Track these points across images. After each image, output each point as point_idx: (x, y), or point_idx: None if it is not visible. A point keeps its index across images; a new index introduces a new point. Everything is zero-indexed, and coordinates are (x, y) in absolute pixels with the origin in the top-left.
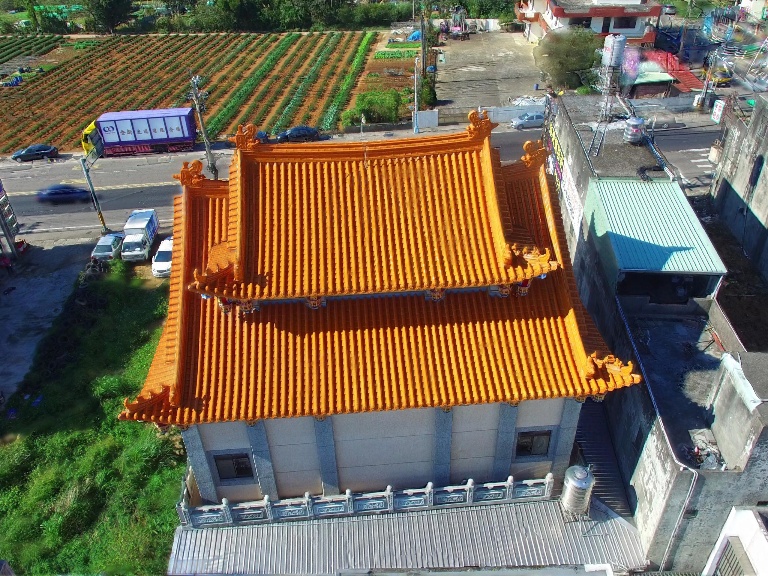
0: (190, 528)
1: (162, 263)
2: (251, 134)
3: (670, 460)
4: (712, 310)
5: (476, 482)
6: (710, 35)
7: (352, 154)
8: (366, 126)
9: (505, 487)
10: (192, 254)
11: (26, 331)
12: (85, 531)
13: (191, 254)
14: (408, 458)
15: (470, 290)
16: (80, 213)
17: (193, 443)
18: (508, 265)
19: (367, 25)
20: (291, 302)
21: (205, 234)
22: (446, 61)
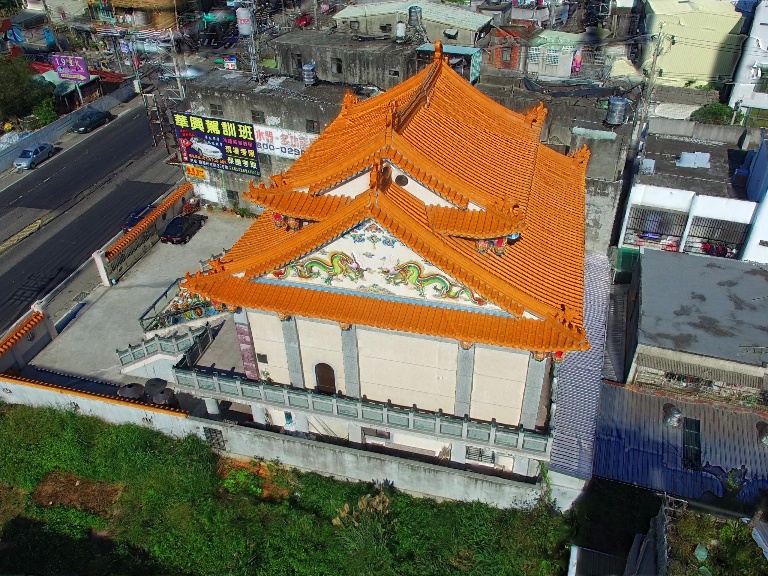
0: None
1: None
2: None
3: (611, 185)
4: None
5: None
6: (94, 30)
7: None
8: None
9: None
10: None
11: None
12: None
13: None
14: None
15: None
16: None
17: None
18: None
19: None
20: None
21: None
22: None
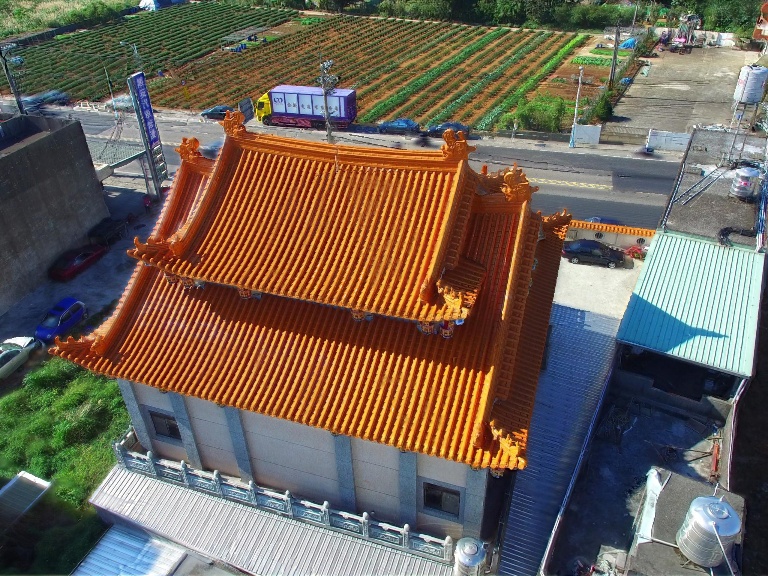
0: (125, 468)
1: None
2: (236, 121)
3: None
4: (728, 417)
5: (373, 518)
6: None
7: (327, 155)
8: (520, 132)
9: (401, 533)
10: (172, 223)
11: (133, 263)
12: (84, 443)
13: (171, 223)
14: (315, 470)
15: (400, 318)
16: None
17: (127, 393)
18: (424, 301)
19: (583, 27)
20: (232, 287)
21: (188, 207)
22: (648, 74)
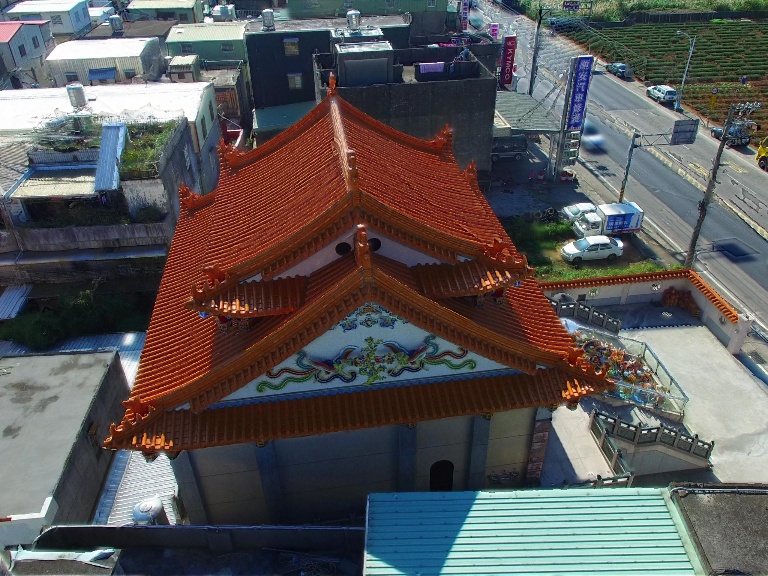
0: None
1: (573, 246)
2: None
3: None
4: None
5: None
6: None
7: None
8: None
9: None
10: None
11: None
12: None
13: None
14: None
15: None
16: (644, 188)
17: None
18: None
19: None
20: None
21: None
22: None
